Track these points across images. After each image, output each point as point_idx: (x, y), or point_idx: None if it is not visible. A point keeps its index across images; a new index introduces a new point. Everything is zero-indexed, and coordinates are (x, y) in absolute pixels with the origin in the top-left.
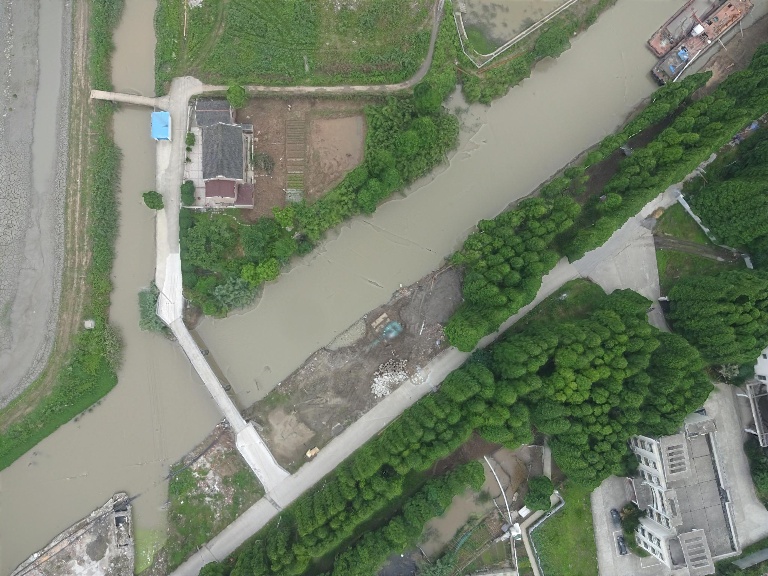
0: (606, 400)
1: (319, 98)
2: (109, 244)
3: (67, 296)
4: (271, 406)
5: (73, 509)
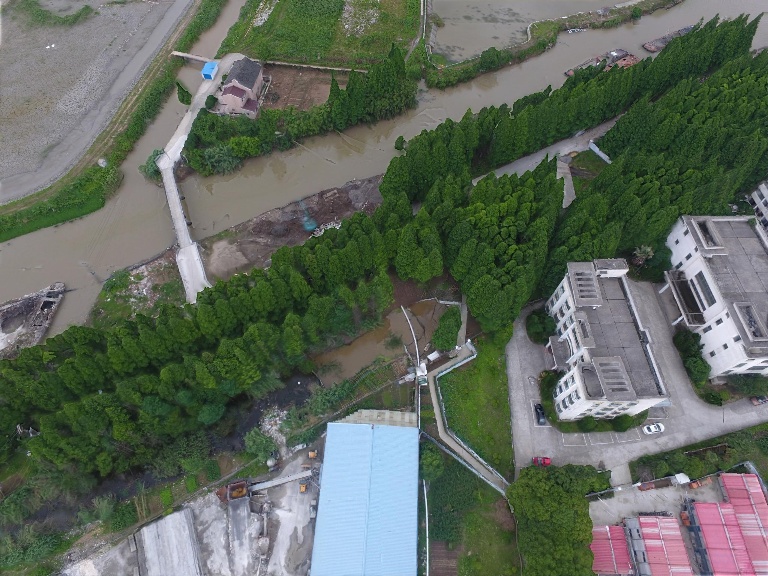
0: (513, 224)
1: (322, 71)
2: (143, 125)
3: (96, 146)
4: (219, 238)
5: (13, 292)
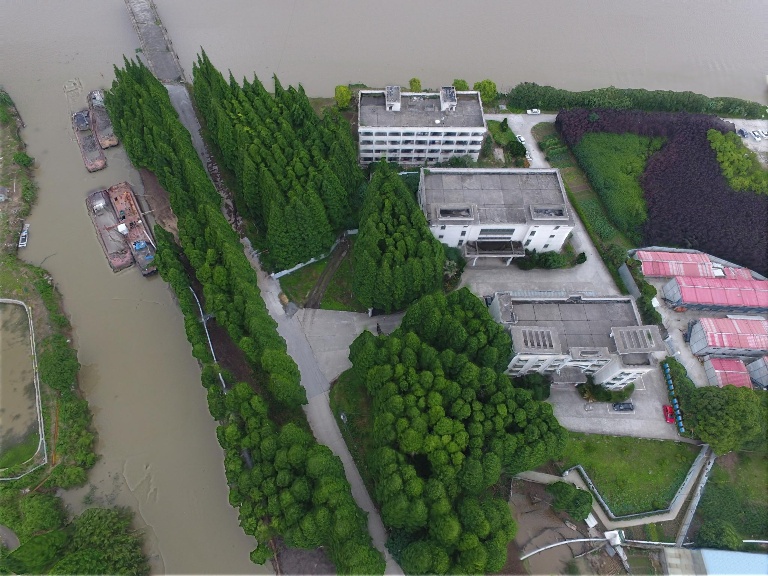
0: (467, 404)
1: None
2: None
3: None
4: None
5: None
